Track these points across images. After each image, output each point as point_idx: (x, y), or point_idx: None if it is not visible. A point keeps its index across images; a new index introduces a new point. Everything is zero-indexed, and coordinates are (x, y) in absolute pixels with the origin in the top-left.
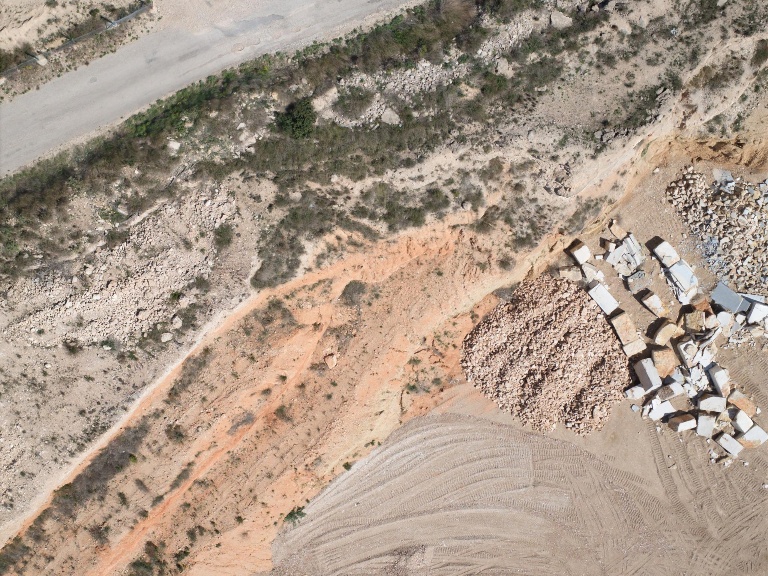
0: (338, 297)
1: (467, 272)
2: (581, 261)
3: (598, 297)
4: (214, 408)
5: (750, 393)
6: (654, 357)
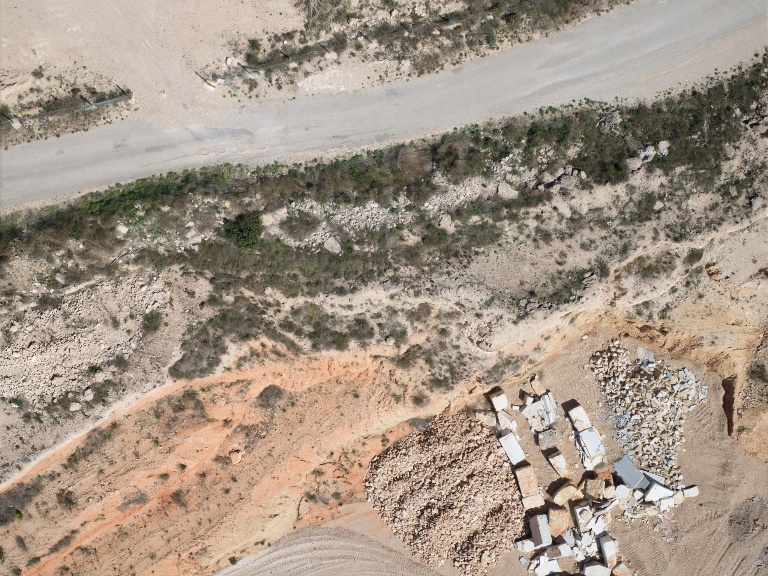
0: (255, 397)
1: (382, 400)
2: (497, 408)
3: (507, 446)
4: (109, 482)
5: (635, 568)
6: (550, 515)
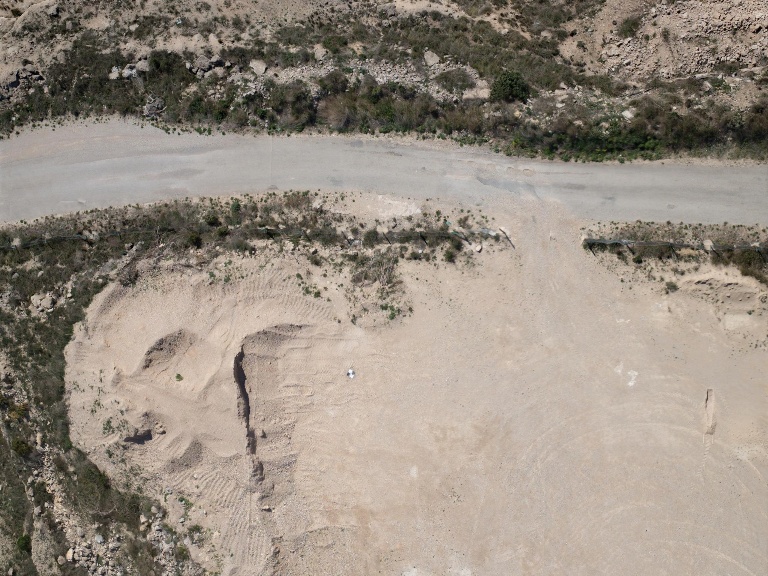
0: None
1: None
2: None
3: None
4: None
5: None
6: None
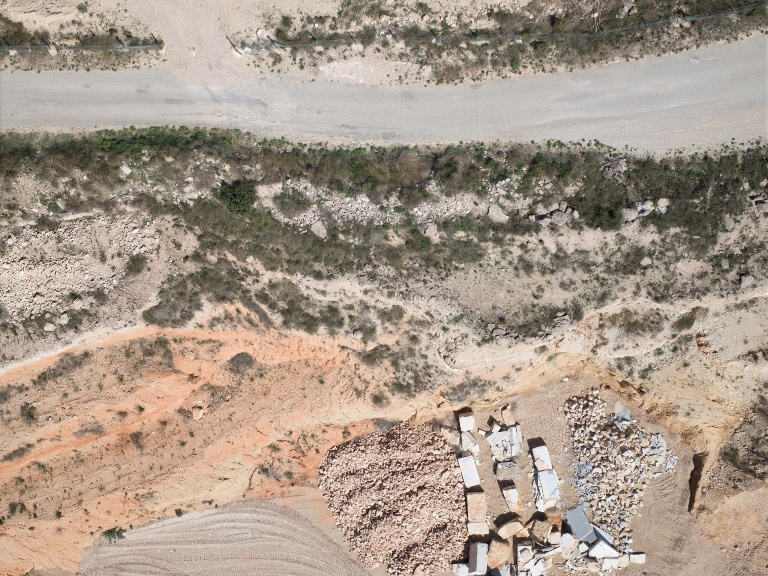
0: (227, 360)
1: (345, 391)
2: (463, 428)
3: (465, 467)
4: (70, 407)
5: None
6: (491, 545)
